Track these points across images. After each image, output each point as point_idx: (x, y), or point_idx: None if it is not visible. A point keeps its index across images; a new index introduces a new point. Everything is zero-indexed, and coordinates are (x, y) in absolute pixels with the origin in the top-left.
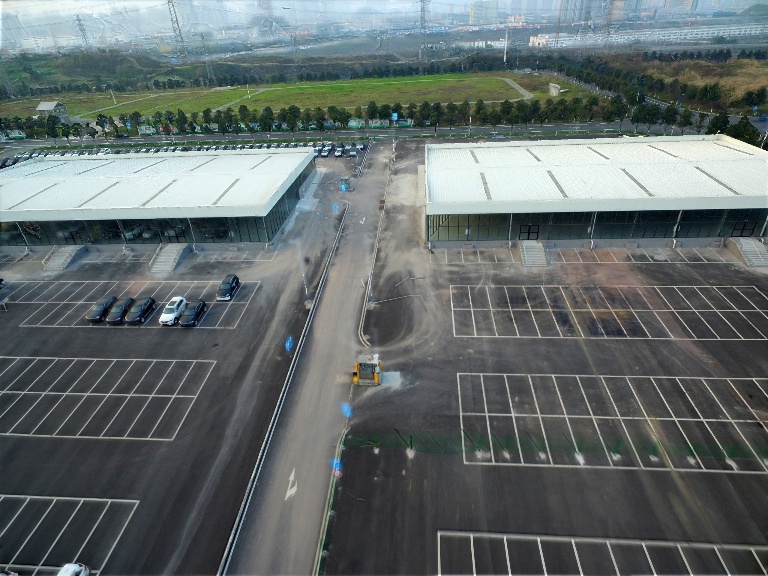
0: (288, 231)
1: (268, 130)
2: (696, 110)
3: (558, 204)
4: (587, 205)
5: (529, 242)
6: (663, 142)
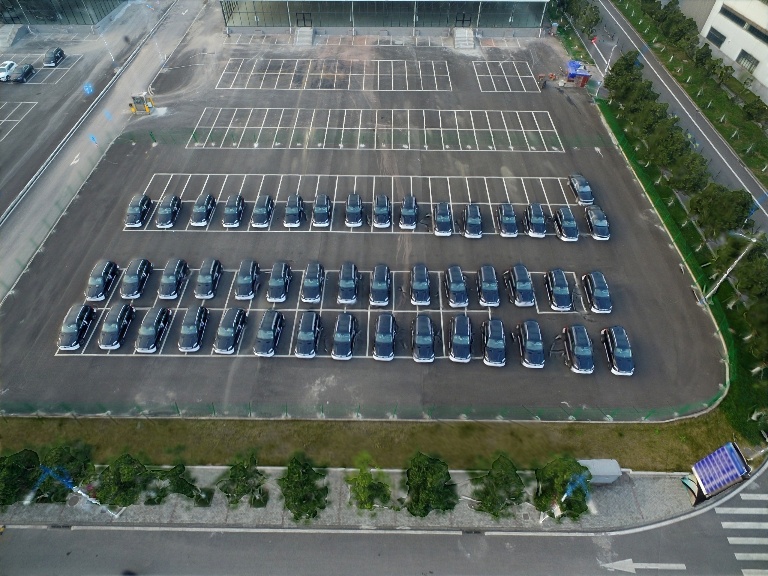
0: (117, 19)
1: None
2: None
3: None
4: None
5: (304, 28)
6: None
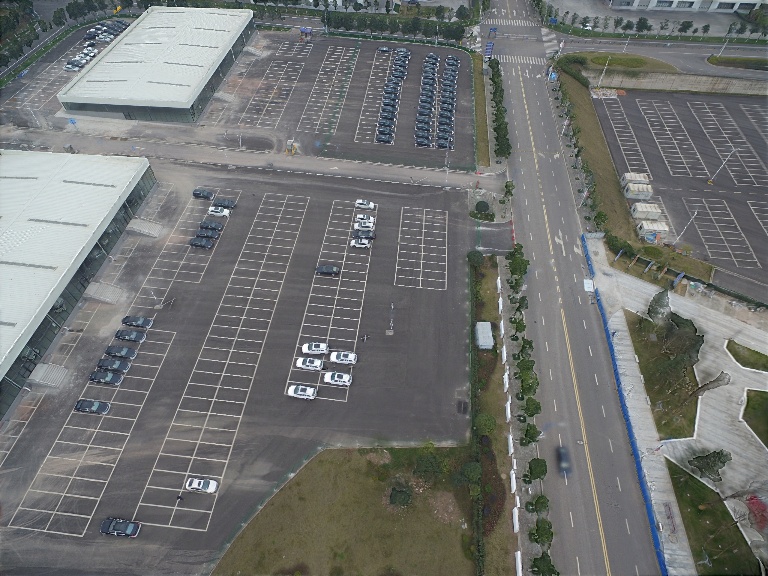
0: None
1: None
2: None
3: None
4: None
5: (216, 94)
6: (141, 23)
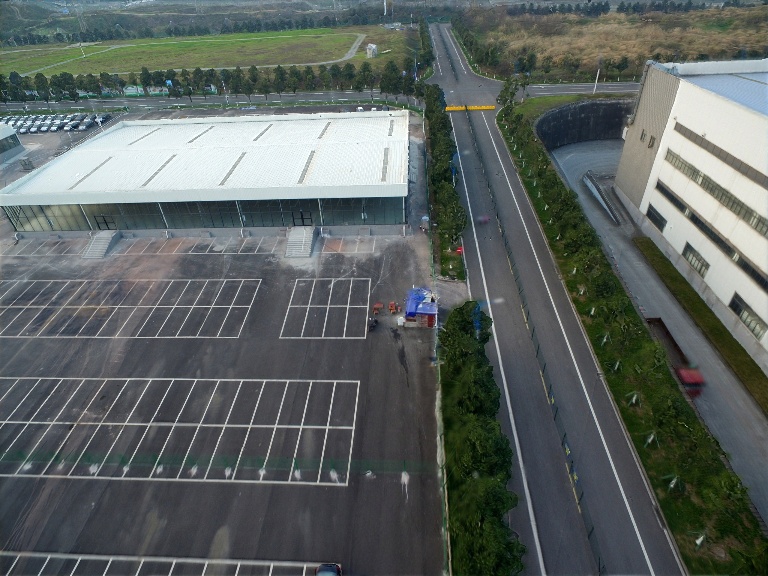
0: None
1: (21, 100)
2: (483, 75)
3: (117, 195)
4: (145, 196)
5: (105, 232)
6: (349, 119)
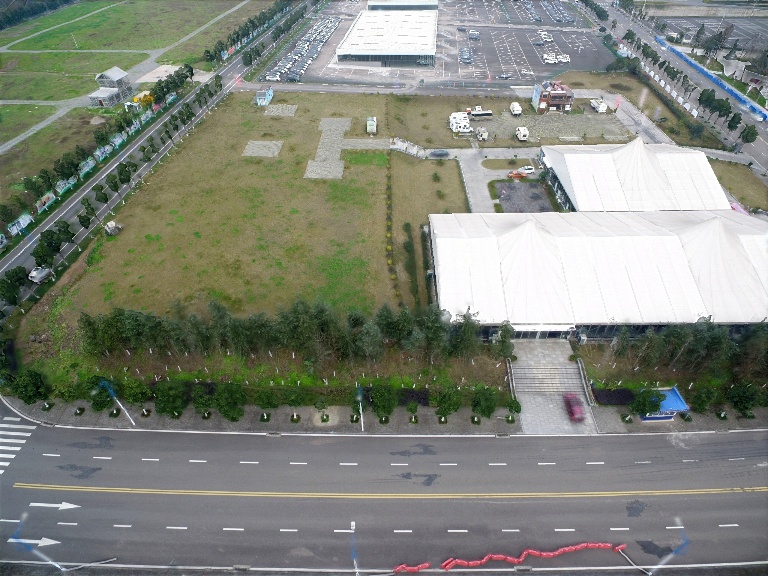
0: None
1: None
2: None
3: None
4: None
5: (439, 8)
6: None
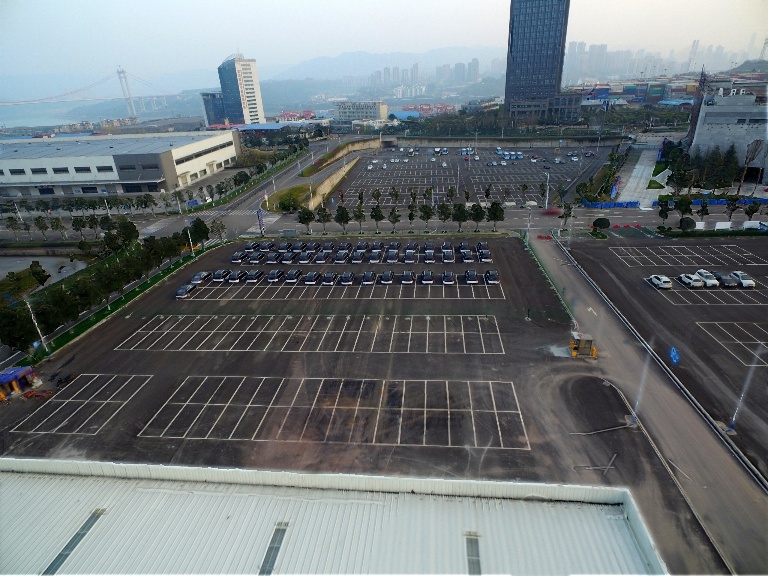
0: None
1: None
2: None
3: (326, 481)
4: None
5: None
6: None
